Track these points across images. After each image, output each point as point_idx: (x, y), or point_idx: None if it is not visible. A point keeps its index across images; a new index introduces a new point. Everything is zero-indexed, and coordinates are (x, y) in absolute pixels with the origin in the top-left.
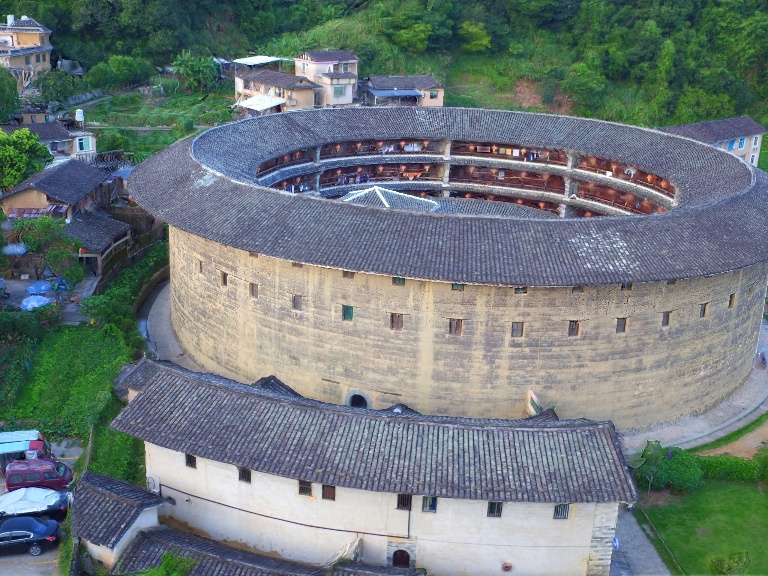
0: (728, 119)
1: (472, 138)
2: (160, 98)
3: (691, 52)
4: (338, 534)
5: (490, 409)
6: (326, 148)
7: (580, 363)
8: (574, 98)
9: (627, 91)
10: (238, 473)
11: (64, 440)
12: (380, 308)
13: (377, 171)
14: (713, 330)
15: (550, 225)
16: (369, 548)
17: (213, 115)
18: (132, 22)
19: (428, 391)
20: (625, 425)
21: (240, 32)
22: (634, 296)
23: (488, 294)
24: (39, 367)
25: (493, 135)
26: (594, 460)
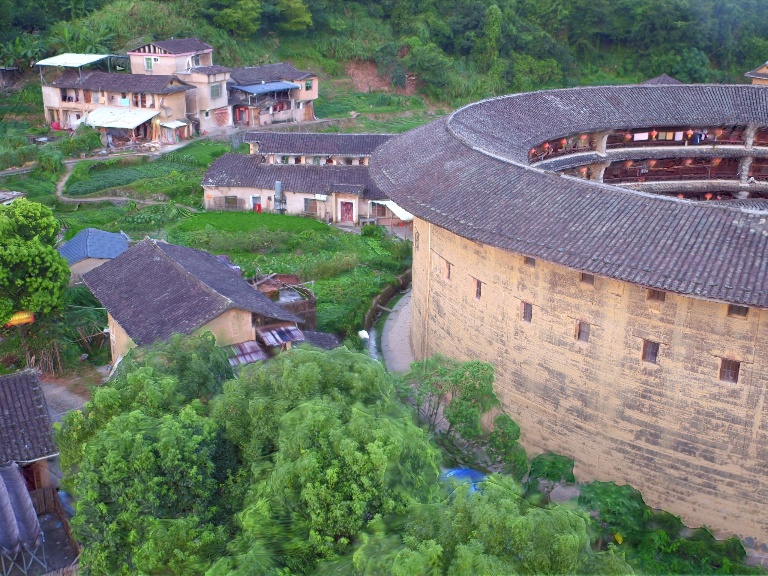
0: (662, 79)
1: (635, 124)
2: None
3: (508, 17)
4: None
5: None
6: None
7: None
8: (425, 76)
9: (458, 64)
10: None
11: None
12: None
13: None
14: None
15: None
16: None
17: (78, 142)
18: None
19: None
20: None
21: None
22: None
23: None
24: None
25: (652, 117)
26: None
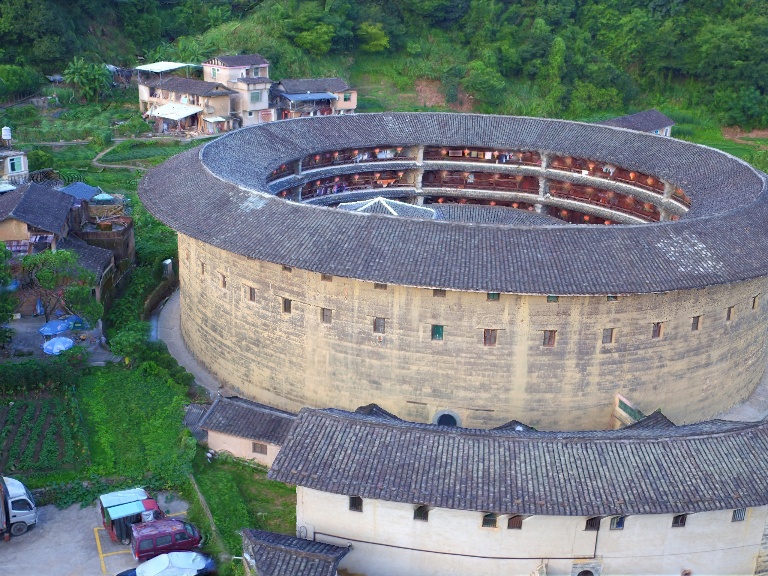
0: (641, 113)
1: (445, 143)
2: (57, 109)
3: (578, 48)
4: (522, 563)
5: (580, 416)
6: (304, 159)
7: (661, 363)
8: (476, 96)
9: (522, 87)
10: (413, 512)
11: (159, 494)
12: (473, 325)
13: (352, 180)
14: (759, 320)
15: (633, 231)
16: (553, 573)
17: (130, 126)
18: (14, 28)
19: (521, 404)
20: (694, 419)
21: (125, 36)
22: (707, 295)
23: (582, 303)
24: (92, 416)
25: (465, 139)
26: (767, 461)
